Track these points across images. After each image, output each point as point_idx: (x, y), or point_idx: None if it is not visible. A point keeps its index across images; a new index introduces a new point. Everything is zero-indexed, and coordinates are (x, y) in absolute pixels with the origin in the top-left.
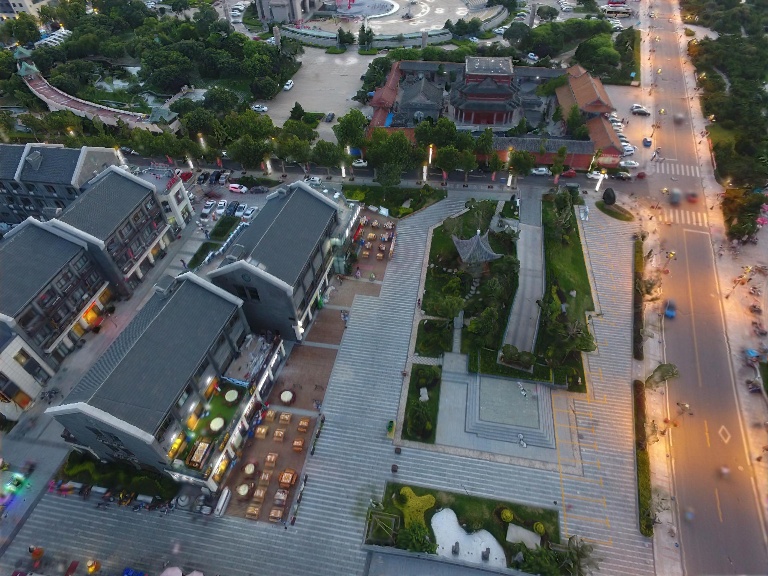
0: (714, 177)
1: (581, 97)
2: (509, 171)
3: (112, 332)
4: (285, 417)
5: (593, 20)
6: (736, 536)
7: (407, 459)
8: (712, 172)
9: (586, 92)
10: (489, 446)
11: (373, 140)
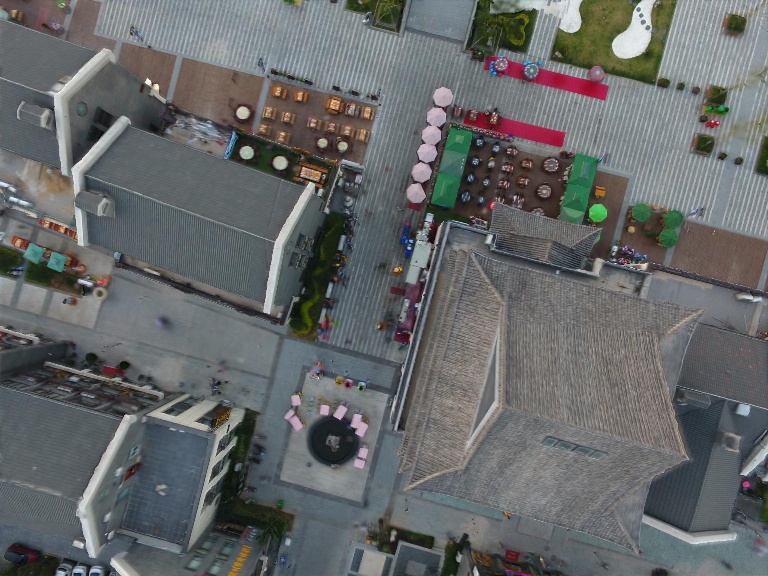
0: None
1: None
2: None
3: (128, 348)
4: (269, 112)
5: None
6: None
7: None
8: None
9: None
10: None
11: None
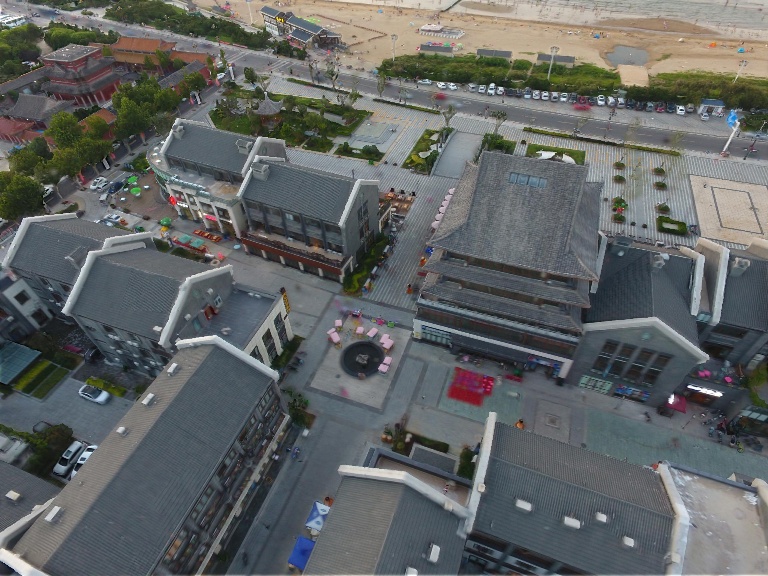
0: (253, 50)
1: (145, 48)
2: (198, 90)
3: None
4: None
5: (19, 27)
6: (444, 99)
7: (391, 161)
8: (248, 50)
9: (143, 44)
10: (392, 139)
11: (93, 130)
